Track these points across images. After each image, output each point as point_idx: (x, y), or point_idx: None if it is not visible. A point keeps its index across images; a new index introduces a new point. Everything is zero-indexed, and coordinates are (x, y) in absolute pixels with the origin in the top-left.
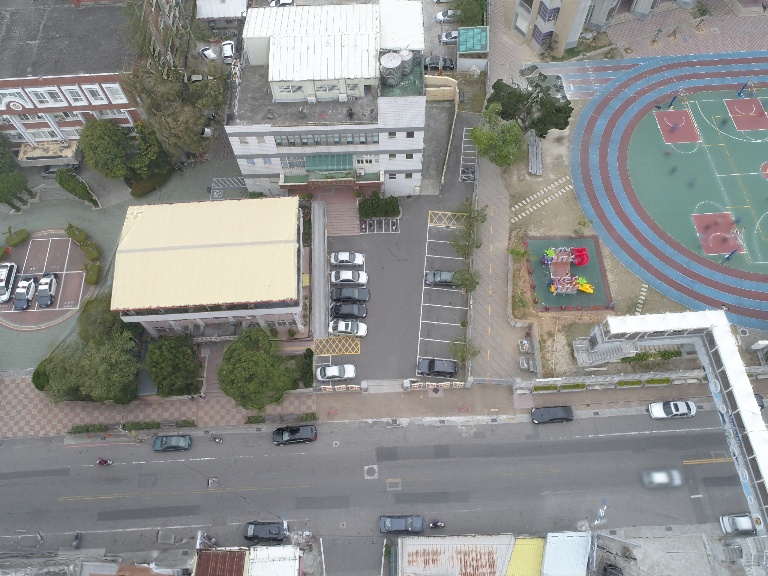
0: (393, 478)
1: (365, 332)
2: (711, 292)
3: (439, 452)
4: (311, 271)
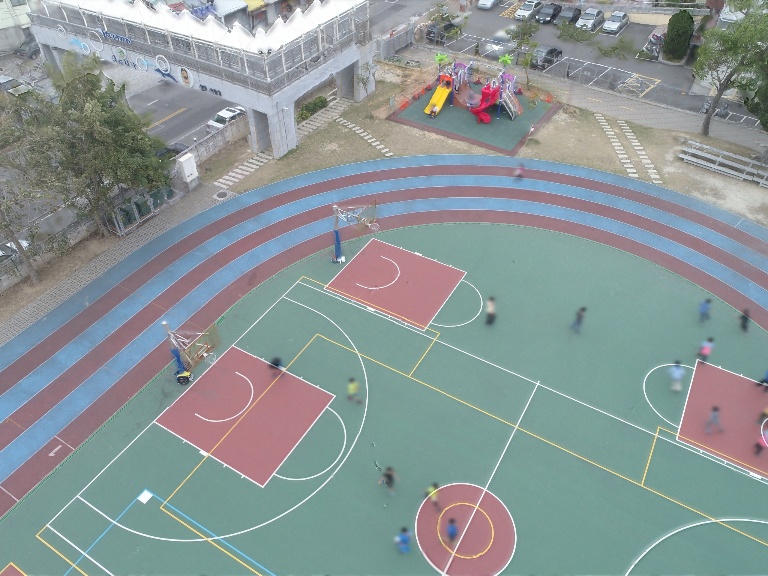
0: (376, 5)
1: (518, 14)
2: (310, 203)
3: (371, 22)
4: (611, 0)
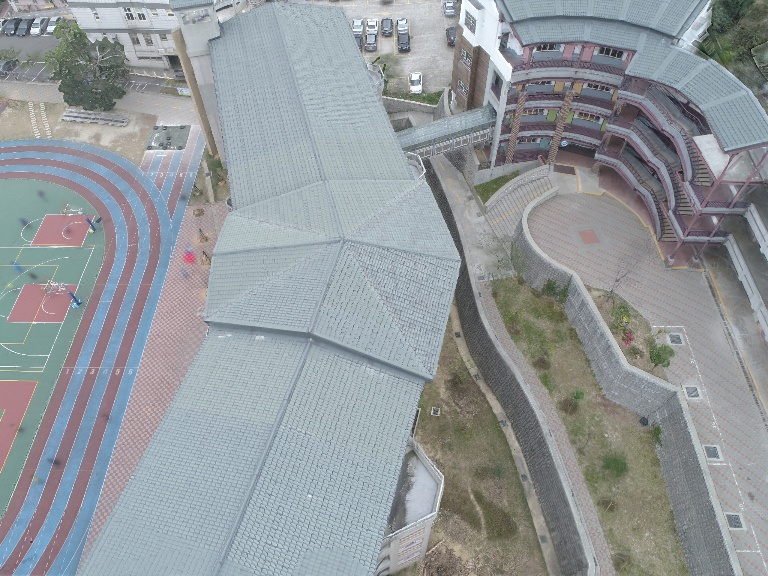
0: None
1: None
2: None
3: None
4: (52, 7)
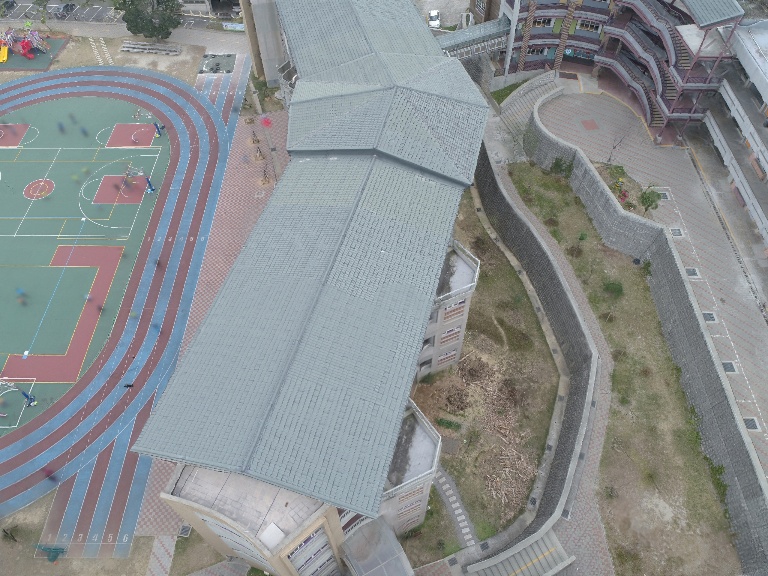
0: None
1: None
2: None
3: None
4: None
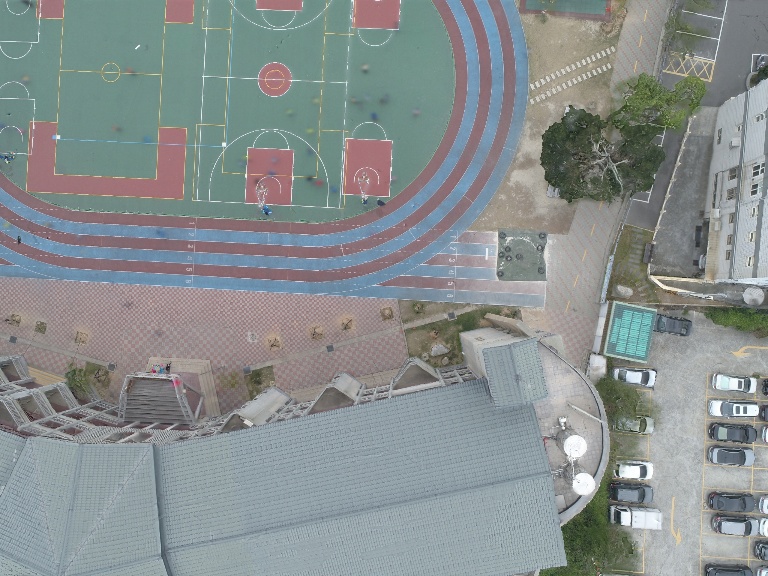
0: None
1: None
2: None
3: None
4: None
